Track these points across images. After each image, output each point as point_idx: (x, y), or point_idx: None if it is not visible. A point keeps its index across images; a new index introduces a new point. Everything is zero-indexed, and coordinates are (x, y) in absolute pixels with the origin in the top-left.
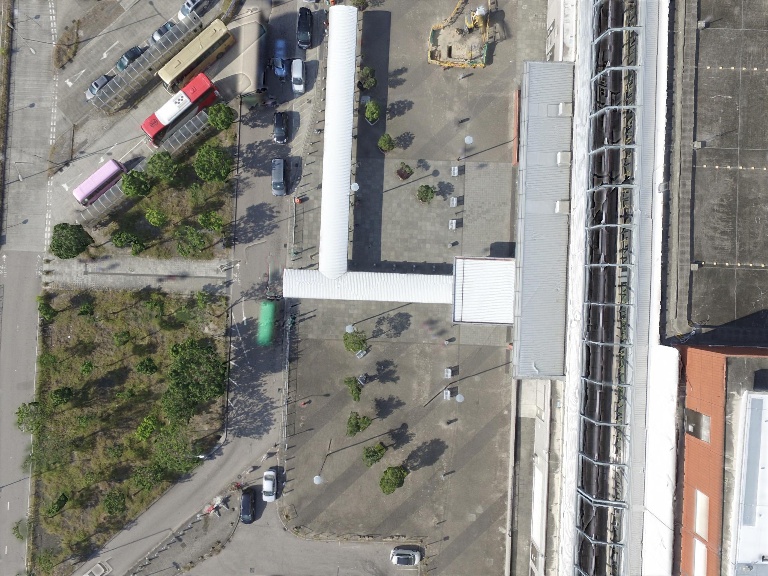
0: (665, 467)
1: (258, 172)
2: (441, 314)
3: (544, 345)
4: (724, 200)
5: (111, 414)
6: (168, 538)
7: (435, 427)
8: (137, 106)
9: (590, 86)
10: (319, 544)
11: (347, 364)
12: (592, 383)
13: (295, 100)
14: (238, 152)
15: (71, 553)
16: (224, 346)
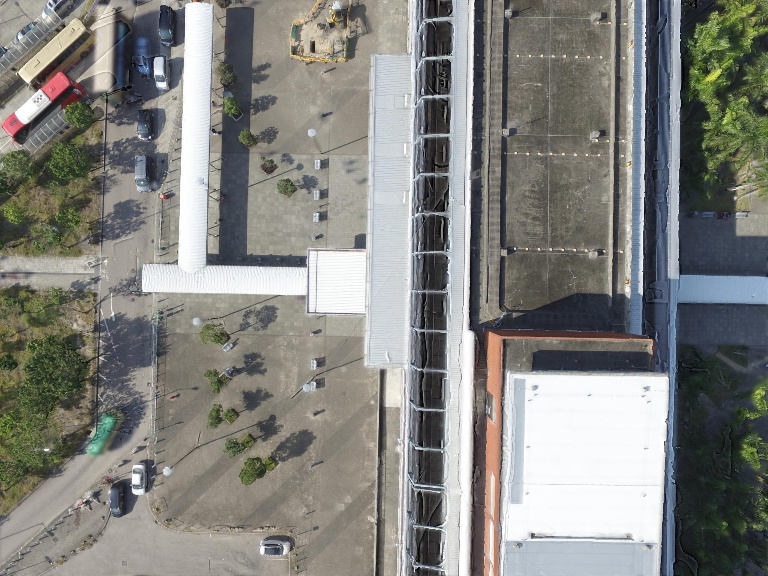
0: (470, 450)
1: (124, 169)
2: None
3: (395, 334)
4: (535, 186)
5: None
6: (40, 533)
7: (303, 418)
8: (4, 106)
9: (415, 77)
10: (190, 536)
11: (215, 357)
12: (436, 371)
13: (160, 97)
14: (104, 150)
15: None
16: (92, 342)
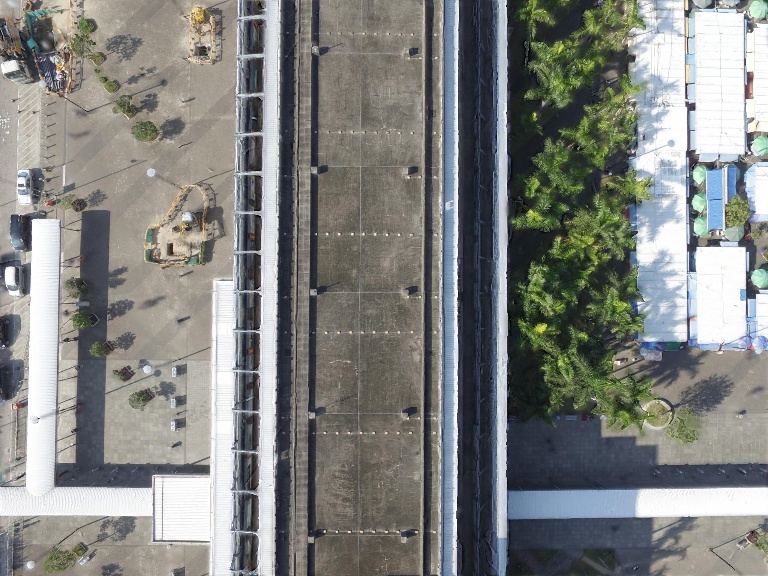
0: None
1: None
2: None
3: None
4: (346, 466)
5: None
6: None
7: None
8: None
9: (235, 335)
10: None
11: (72, 569)
12: None
13: (16, 303)
14: None
15: None
16: None
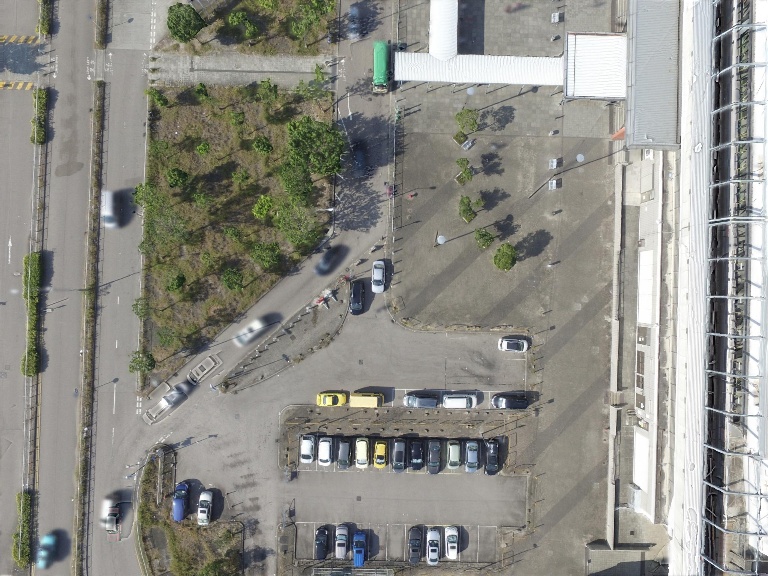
0: None
1: None
2: (544, 107)
3: (657, 114)
4: None
5: (219, 208)
6: (278, 331)
7: (540, 218)
8: None
9: None
10: (427, 335)
11: (452, 157)
12: None
13: None
14: None
15: (181, 346)
16: None
